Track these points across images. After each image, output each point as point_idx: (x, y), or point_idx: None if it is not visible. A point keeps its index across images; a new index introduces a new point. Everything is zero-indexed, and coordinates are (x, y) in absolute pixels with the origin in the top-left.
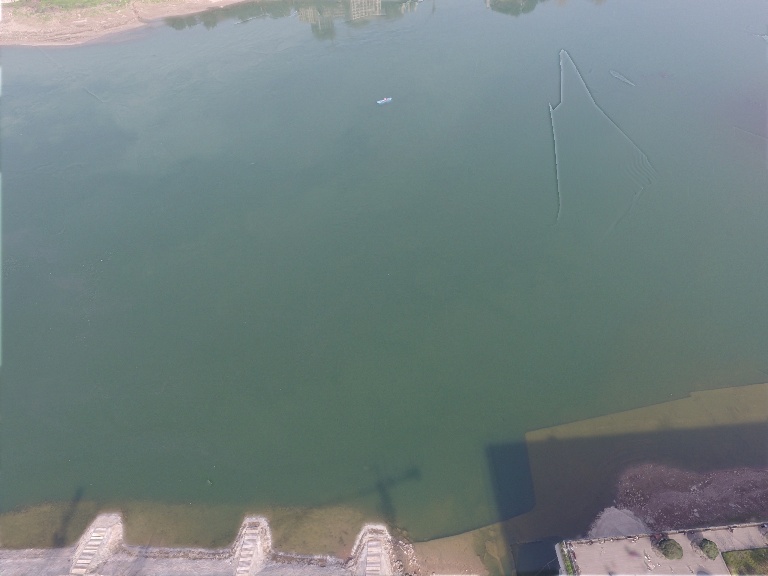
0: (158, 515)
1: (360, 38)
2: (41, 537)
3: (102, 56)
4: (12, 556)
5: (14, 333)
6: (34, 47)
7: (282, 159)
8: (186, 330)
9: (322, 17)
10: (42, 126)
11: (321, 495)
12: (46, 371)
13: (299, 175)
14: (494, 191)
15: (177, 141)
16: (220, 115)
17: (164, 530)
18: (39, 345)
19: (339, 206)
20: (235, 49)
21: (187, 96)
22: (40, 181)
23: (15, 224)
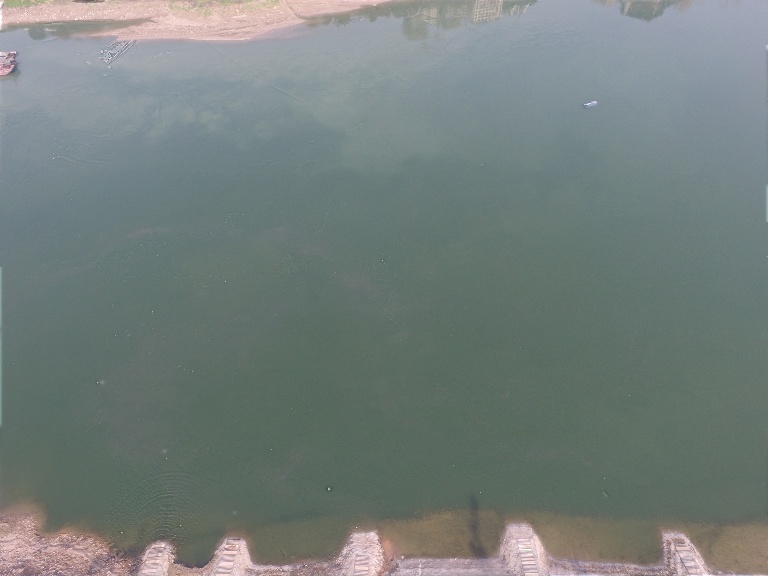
0: (568, 527)
1: (529, 40)
2: (457, 546)
3: (275, 52)
4: (442, 565)
5: (326, 332)
6: (203, 41)
7: (510, 161)
8: (502, 335)
9: (443, 17)
10: (246, 121)
11: (730, 512)
12: (378, 373)
13: (536, 178)
14: (744, 199)
15: (395, 140)
16: (423, 115)
17: (582, 543)
18: (357, 346)
19: (597, 211)
20: (408, 48)
21: (380, 94)
22: (281, 177)
23: (273, 221)
